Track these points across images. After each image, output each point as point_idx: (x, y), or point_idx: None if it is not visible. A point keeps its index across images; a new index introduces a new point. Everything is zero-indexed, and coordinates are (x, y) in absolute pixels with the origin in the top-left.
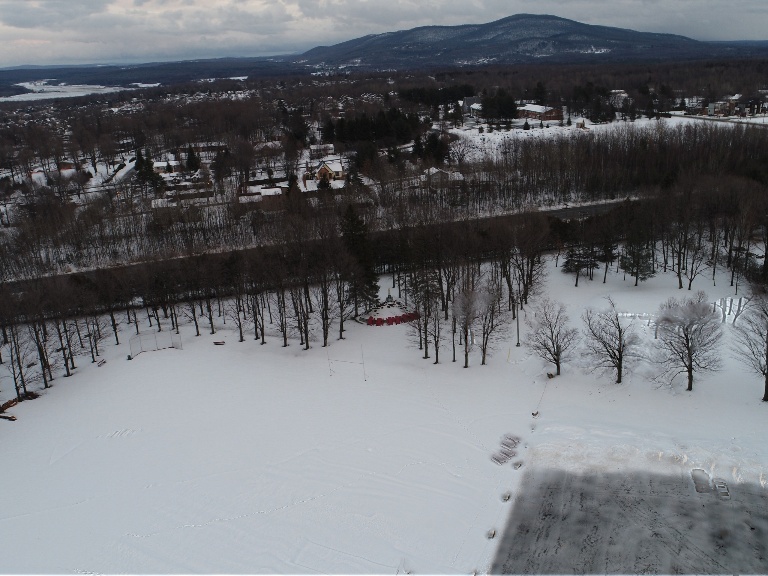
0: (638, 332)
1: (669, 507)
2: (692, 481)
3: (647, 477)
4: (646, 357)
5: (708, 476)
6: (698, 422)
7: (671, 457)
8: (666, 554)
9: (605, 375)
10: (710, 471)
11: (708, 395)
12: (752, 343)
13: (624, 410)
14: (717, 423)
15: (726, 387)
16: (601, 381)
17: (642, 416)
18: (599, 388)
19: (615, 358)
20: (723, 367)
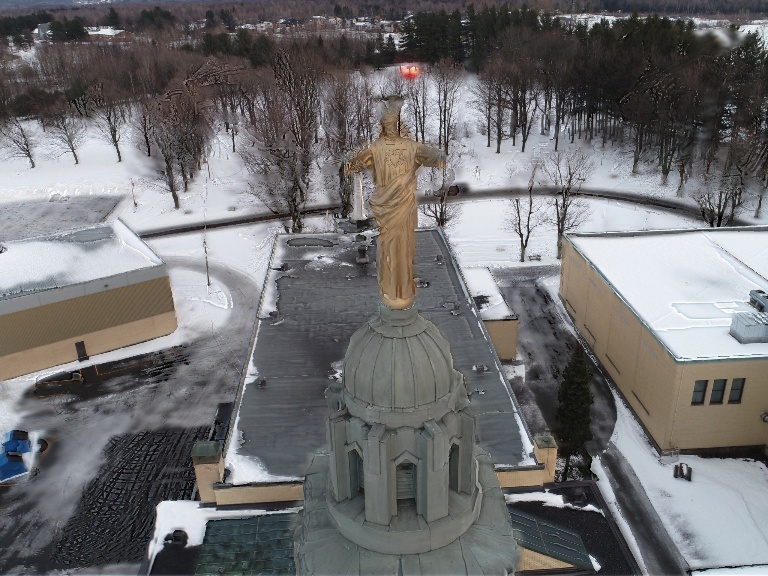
0: (33, 129)
1: (26, 209)
2: (50, 199)
3: (23, 202)
4: (37, 143)
5: (61, 195)
6: (71, 176)
7: (41, 190)
8: (8, 223)
9: (20, 162)
10: (63, 193)
11: (84, 163)
12: (100, 125)
13: (30, 180)
14: (79, 173)
15: (92, 156)
16: (20, 168)
17: (40, 180)
18: (19, 172)
19: (25, 150)
20: (87, 143)
